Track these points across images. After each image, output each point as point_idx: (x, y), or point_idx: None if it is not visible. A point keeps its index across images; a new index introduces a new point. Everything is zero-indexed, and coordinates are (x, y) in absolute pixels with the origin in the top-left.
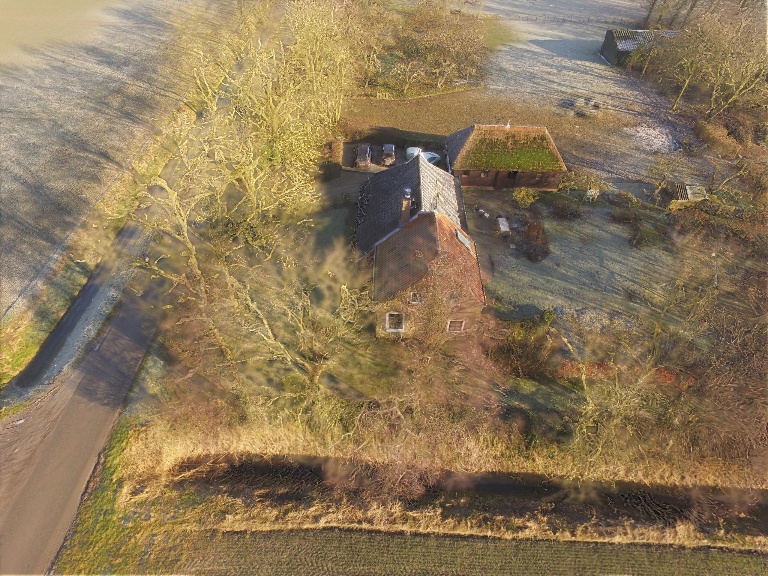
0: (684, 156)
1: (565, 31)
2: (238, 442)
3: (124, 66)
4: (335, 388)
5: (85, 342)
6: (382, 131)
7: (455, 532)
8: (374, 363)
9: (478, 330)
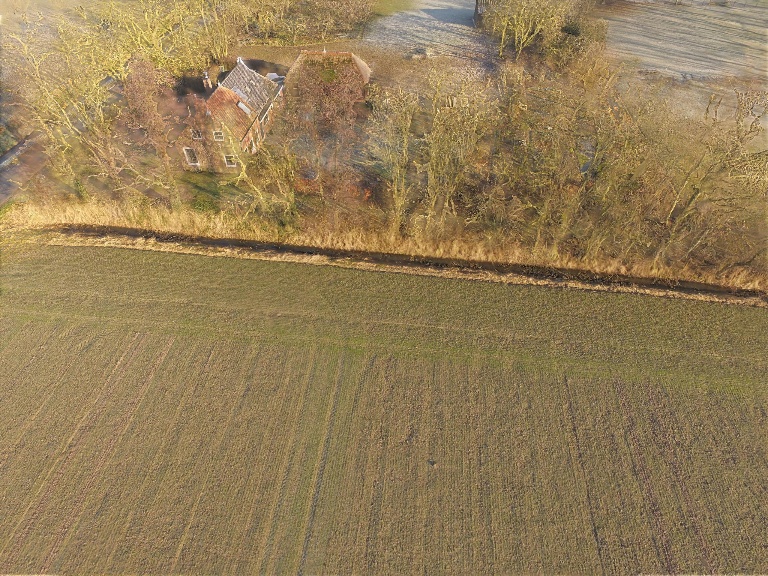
0: (483, 85)
1: (458, 3)
2: (77, 215)
3: (87, 22)
4: (145, 192)
5: (2, 167)
6: (252, 62)
7: (181, 252)
8: (176, 182)
9: (246, 164)
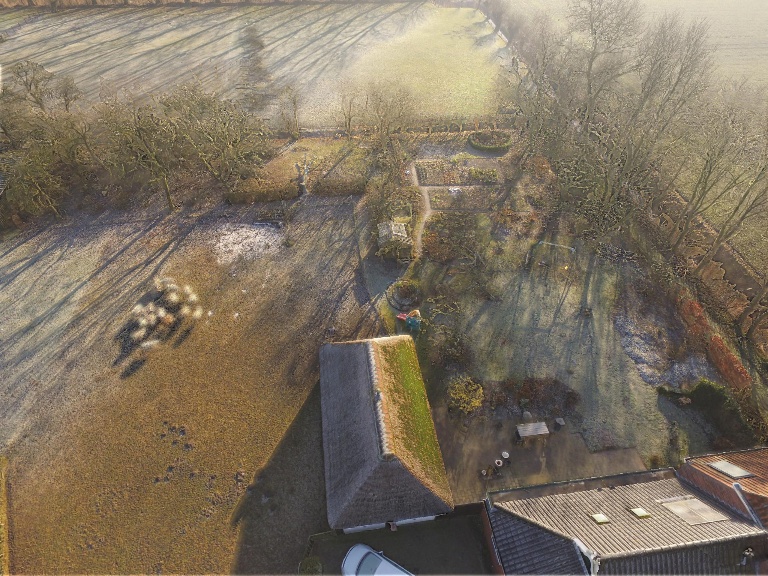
0: (293, 224)
1: None
2: None
3: None
4: None
5: None
6: None
7: None
8: None
9: None
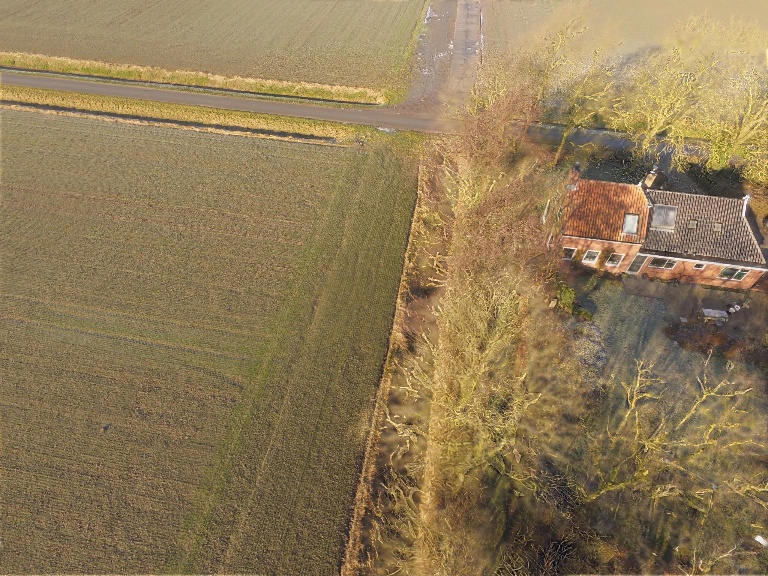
0: None
1: None
2: None
3: None
4: None
5: (517, 123)
6: None
7: None
8: (518, 215)
9: None
